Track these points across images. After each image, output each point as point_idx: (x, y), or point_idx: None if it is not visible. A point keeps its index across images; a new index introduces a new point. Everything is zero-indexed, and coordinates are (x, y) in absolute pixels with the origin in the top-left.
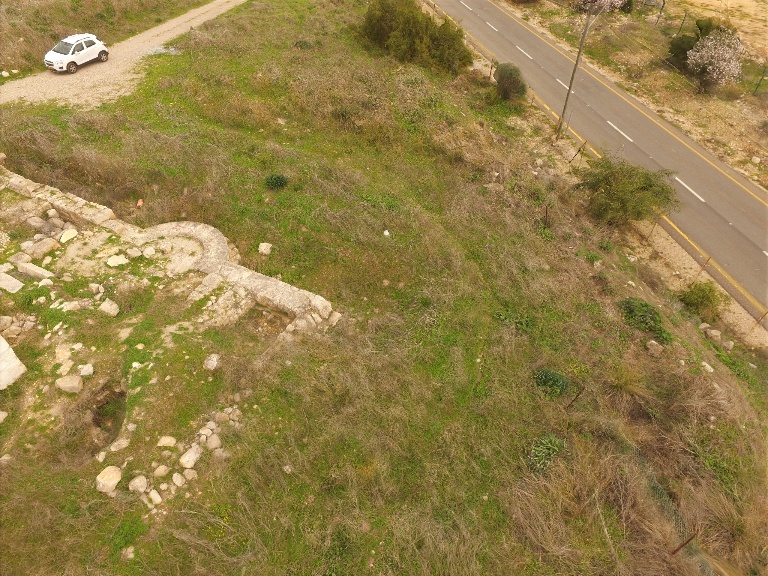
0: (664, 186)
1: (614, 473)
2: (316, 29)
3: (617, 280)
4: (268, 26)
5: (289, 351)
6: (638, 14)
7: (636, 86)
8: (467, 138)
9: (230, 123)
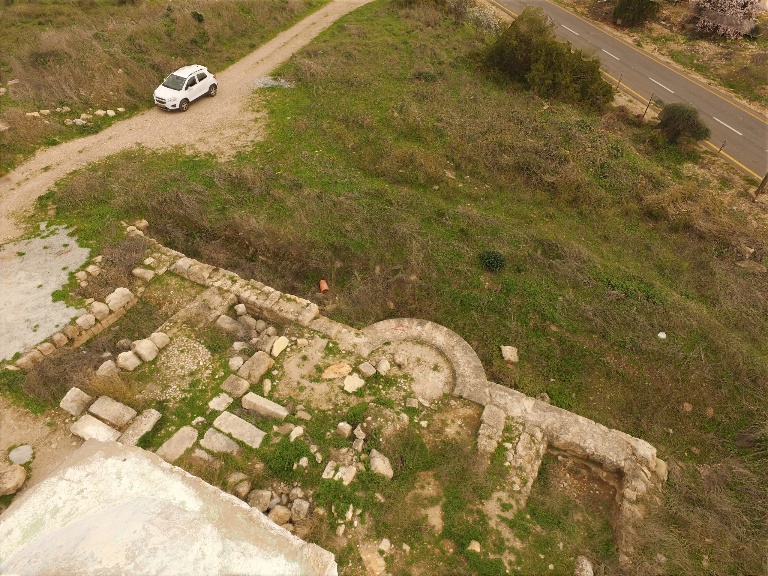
0: None
1: None
2: (428, 57)
3: None
4: (375, 53)
5: (658, 539)
6: (763, 42)
7: None
8: (685, 199)
9: (397, 178)
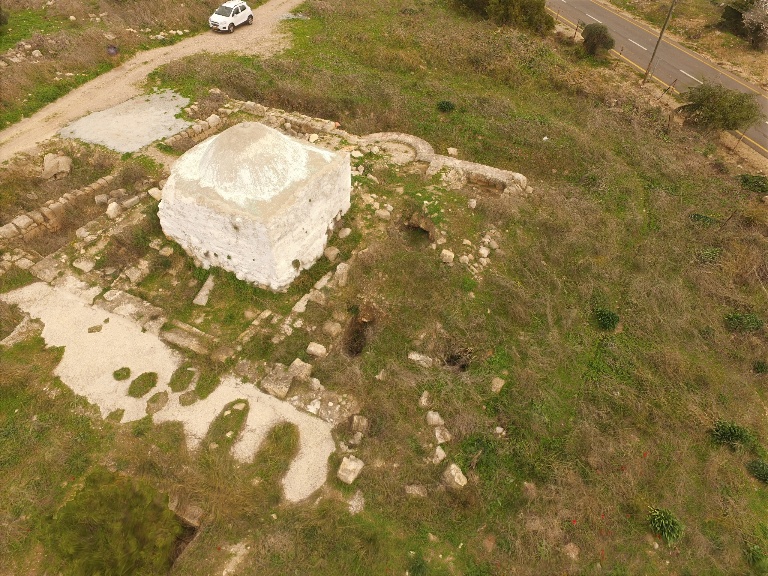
0: (754, 103)
1: (763, 258)
2: (413, 0)
3: (729, 164)
4: None
5: (515, 202)
6: None
7: (696, 45)
8: (582, 77)
9: (386, 68)
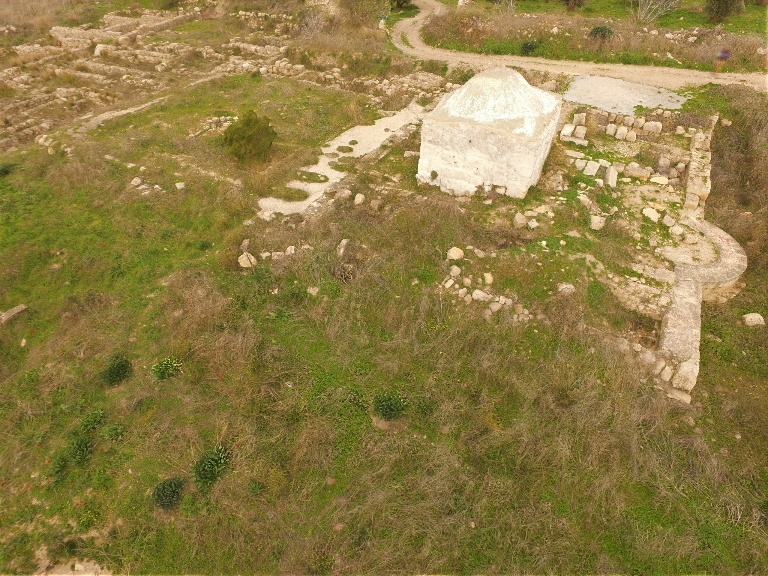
0: None
1: None
2: None
3: None
4: None
5: (605, 347)
6: None
7: None
8: None
9: None
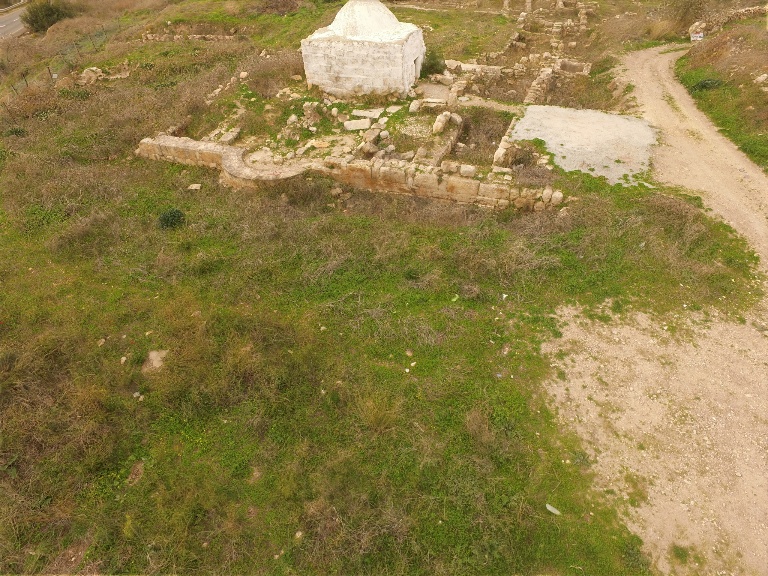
0: None
1: None
2: None
3: None
4: None
5: None
6: None
7: None
8: None
9: None
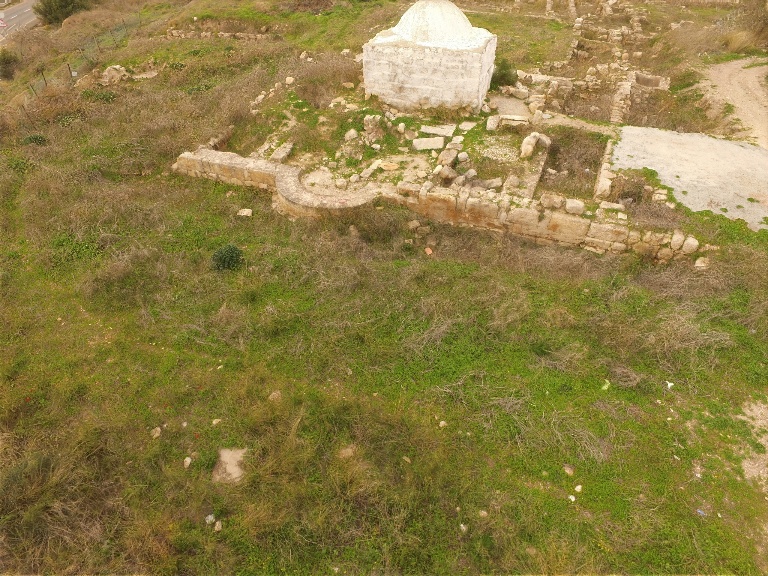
0: None
1: None
2: None
3: None
4: None
5: None
6: None
7: None
8: None
9: None
